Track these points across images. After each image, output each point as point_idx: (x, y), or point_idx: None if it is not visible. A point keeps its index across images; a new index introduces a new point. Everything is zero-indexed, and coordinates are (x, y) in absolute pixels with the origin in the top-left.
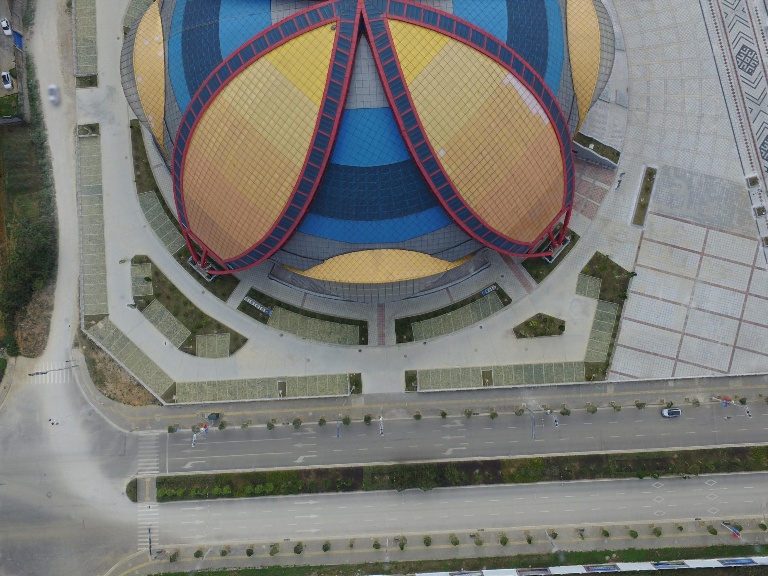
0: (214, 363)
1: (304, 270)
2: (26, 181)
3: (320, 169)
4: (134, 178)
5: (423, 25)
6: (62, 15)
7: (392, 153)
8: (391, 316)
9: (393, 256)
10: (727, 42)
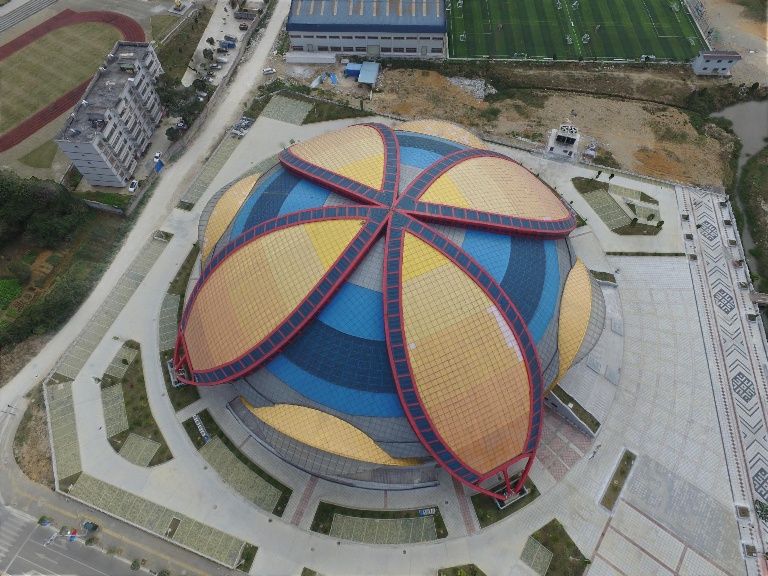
0: (129, 468)
1: (254, 407)
2: (95, 252)
3: (304, 319)
4: (172, 281)
5: (432, 244)
6: (198, 163)
7: (371, 330)
8: (318, 496)
9: (337, 426)
10: (724, 364)
